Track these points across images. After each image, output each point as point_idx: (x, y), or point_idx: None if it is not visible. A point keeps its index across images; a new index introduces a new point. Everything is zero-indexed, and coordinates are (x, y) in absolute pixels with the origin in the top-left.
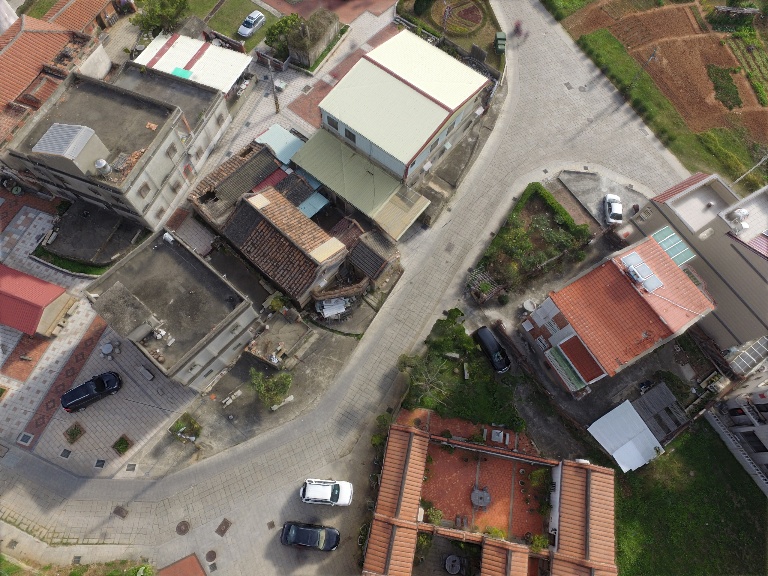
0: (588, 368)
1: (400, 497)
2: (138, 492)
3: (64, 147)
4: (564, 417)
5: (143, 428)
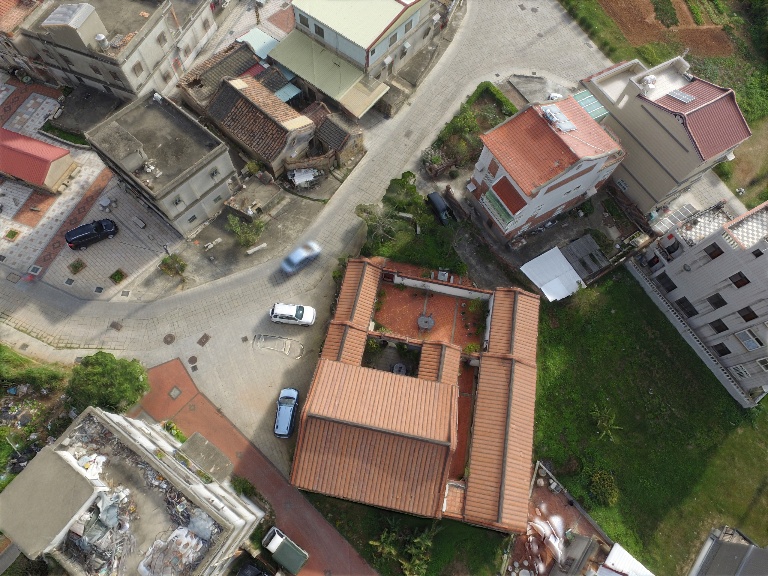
0: (514, 202)
1: (354, 309)
2: (131, 312)
3: (69, 19)
4: (501, 262)
5: (136, 264)
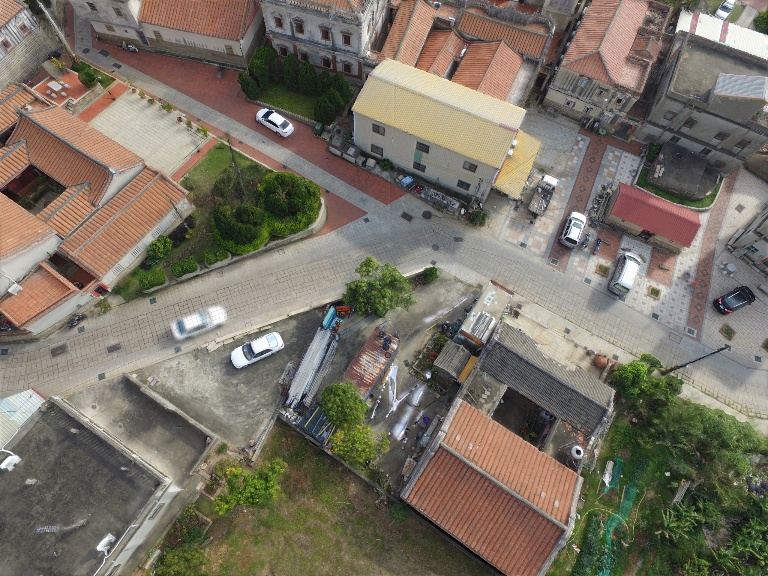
0: None
1: None
2: None
3: (759, 92)
4: None
5: None
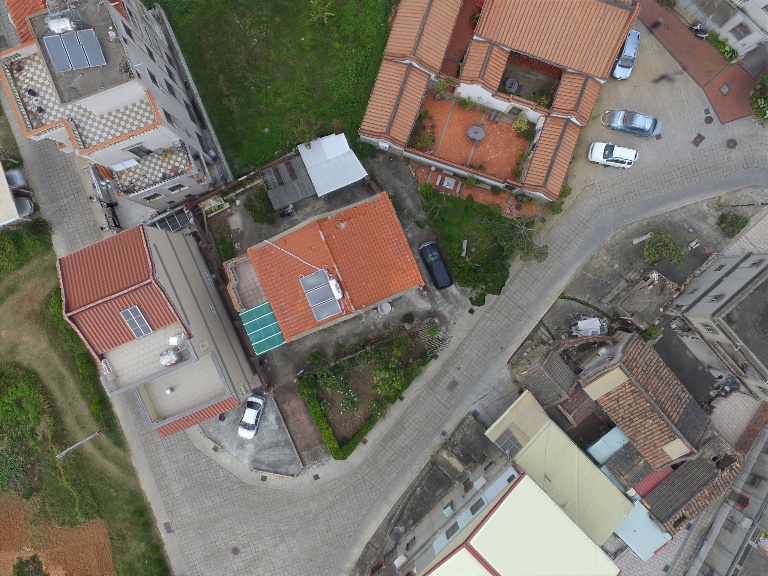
0: None
1: (563, 135)
2: None
3: None
4: None
5: (767, 230)
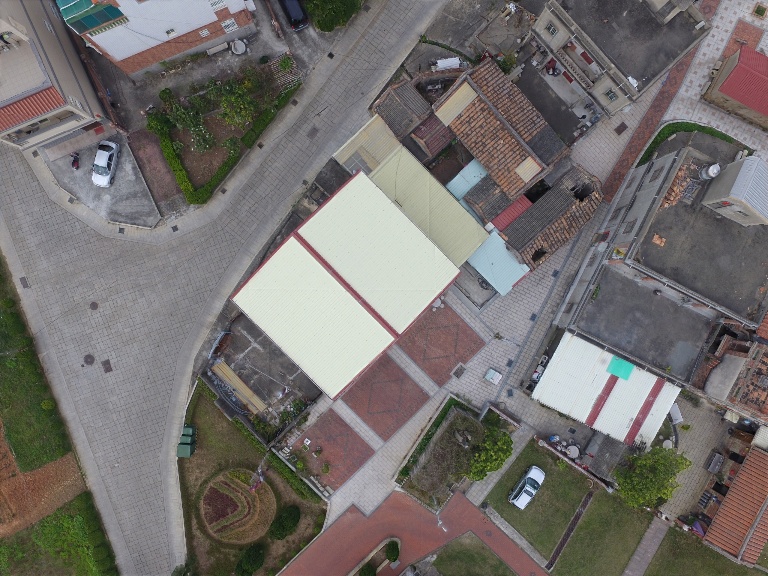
0: None
1: None
2: None
3: (760, 172)
4: None
5: None
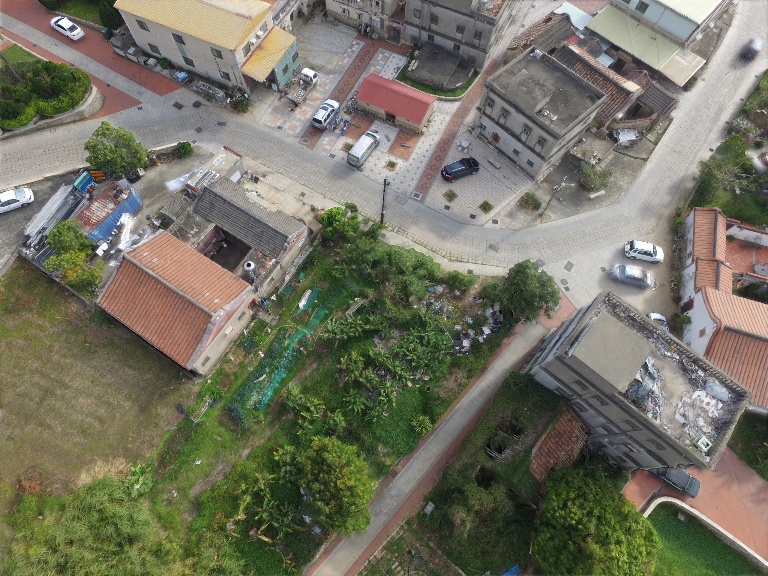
0: None
1: (715, 249)
2: (503, 237)
3: None
4: None
5: (498, 198)
